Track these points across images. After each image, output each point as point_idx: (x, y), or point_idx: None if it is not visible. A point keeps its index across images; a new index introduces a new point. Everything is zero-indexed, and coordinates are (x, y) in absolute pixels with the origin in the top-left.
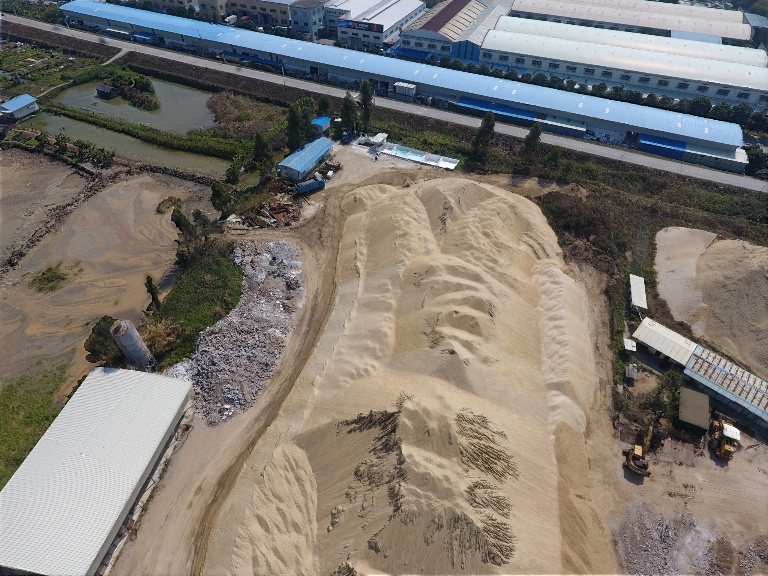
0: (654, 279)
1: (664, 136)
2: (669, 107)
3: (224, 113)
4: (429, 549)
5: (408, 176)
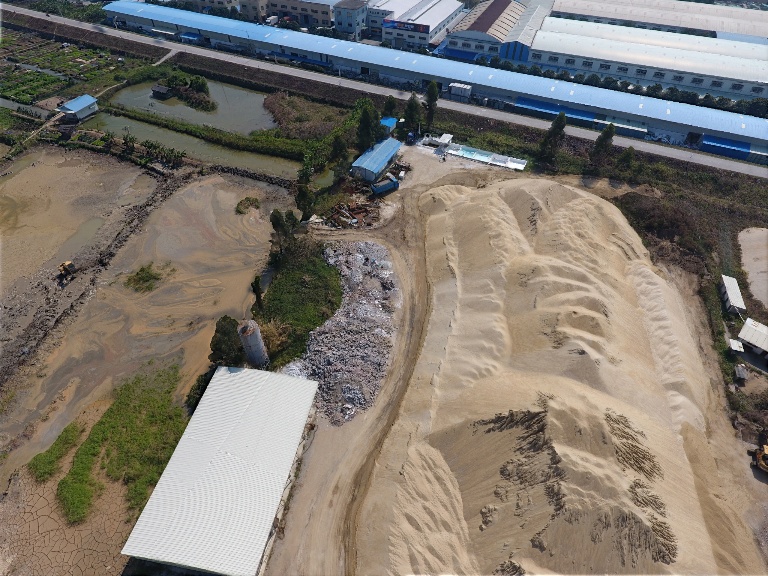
0: (745, 280)
1: (727, 137)
2: (727, 108)
3: (283, 114)
4: (597, 548)
5: (479, 177)
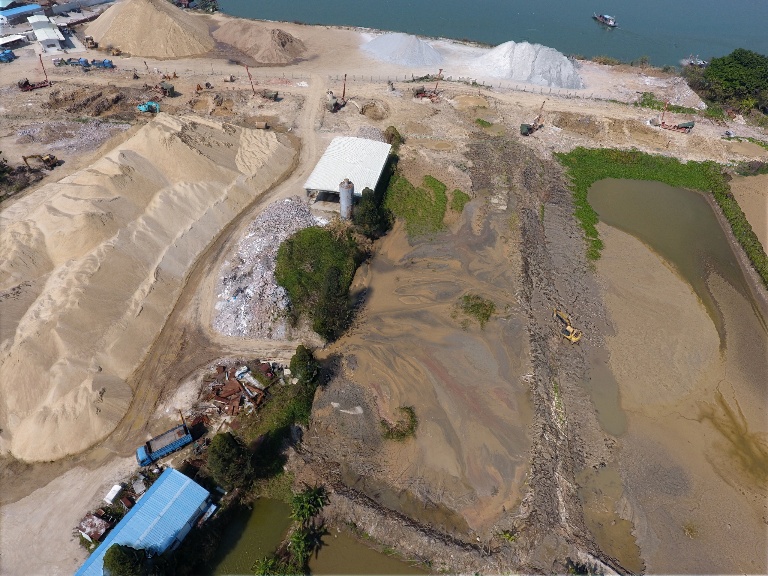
0: None
1: None
2: None
3: None
4: None
5: None
